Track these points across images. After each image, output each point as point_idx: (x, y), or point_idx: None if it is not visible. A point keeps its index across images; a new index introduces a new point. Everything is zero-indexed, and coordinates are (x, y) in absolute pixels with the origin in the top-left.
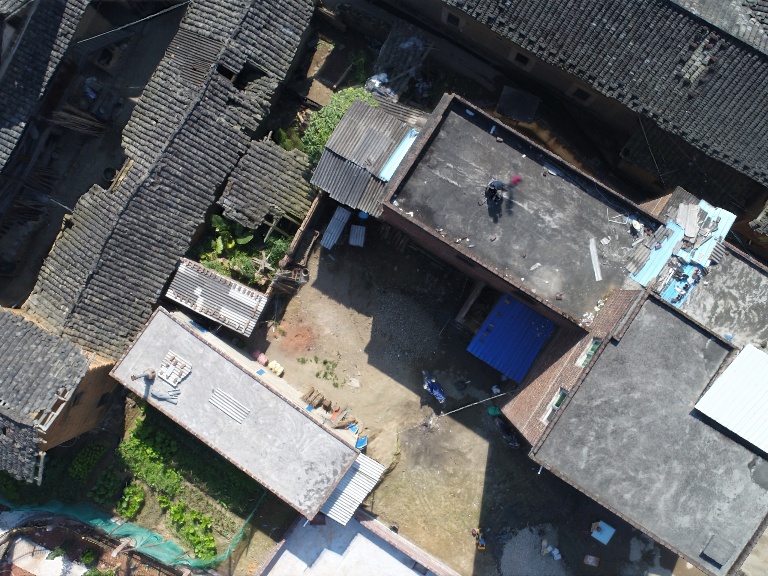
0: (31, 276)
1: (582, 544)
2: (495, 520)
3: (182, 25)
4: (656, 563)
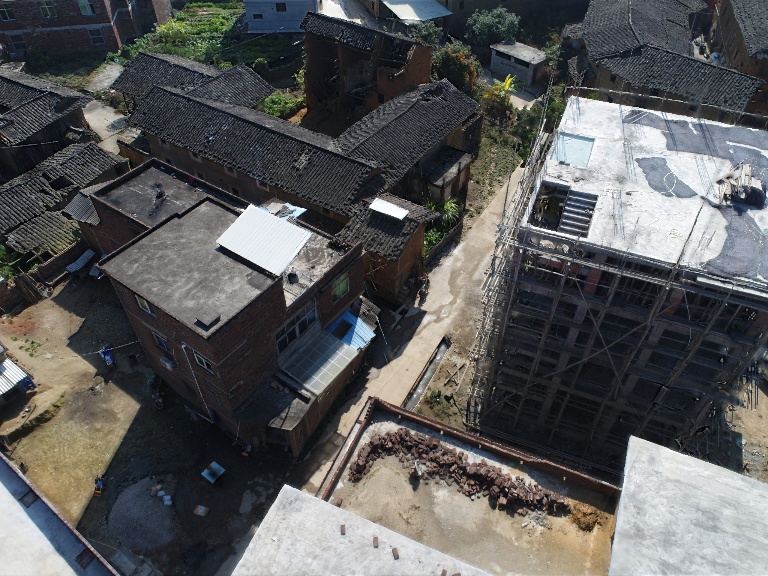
0: None
1: (197, 495)
2: (122, 470)
3: (37, 166)
4: None
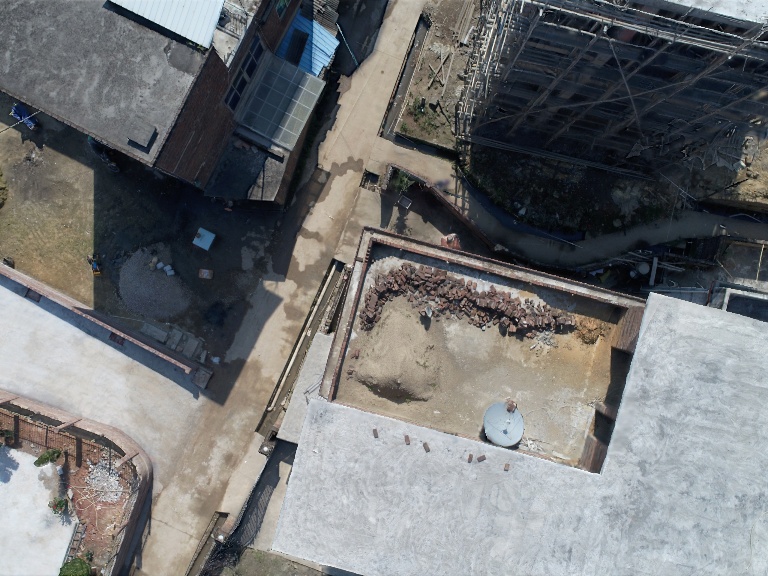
0: None
1: (195, 259)
2: (109, 246)
3: None
4: (269, 270)
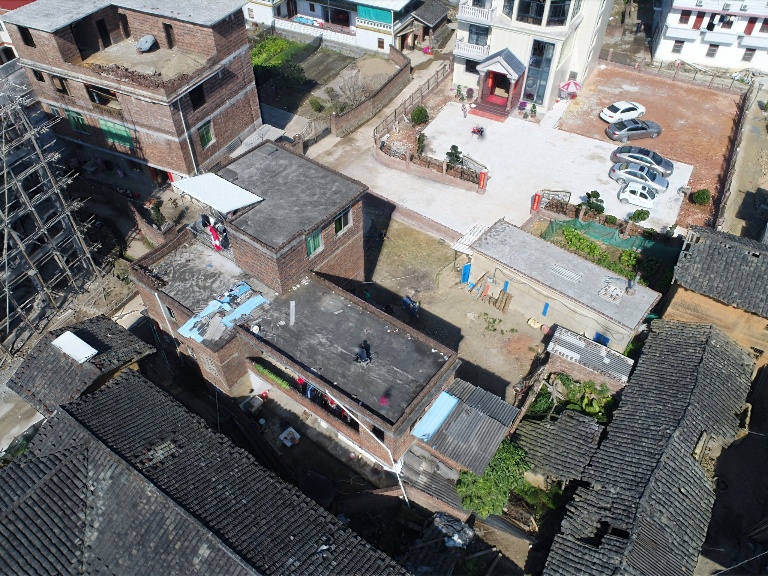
0: (765, 405)
1: None
2: (372, 243)
3: None
4: None
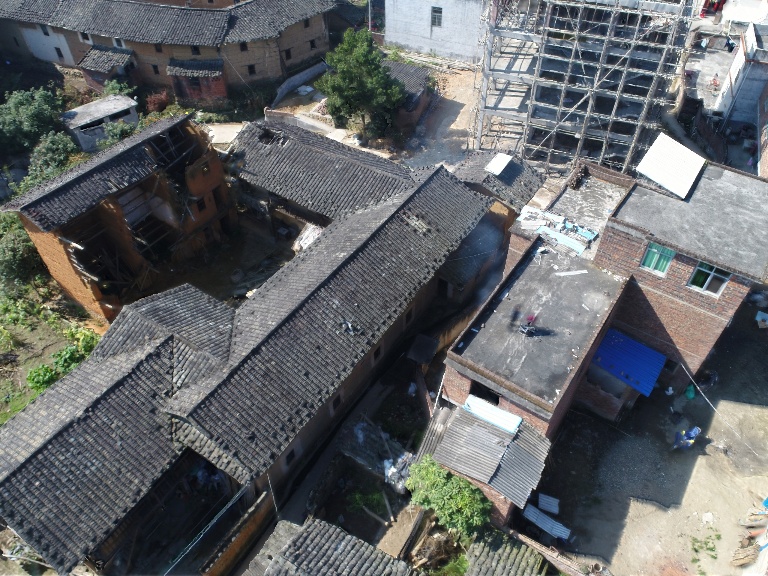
0: None
1: None
2: None
3: None
4: None
